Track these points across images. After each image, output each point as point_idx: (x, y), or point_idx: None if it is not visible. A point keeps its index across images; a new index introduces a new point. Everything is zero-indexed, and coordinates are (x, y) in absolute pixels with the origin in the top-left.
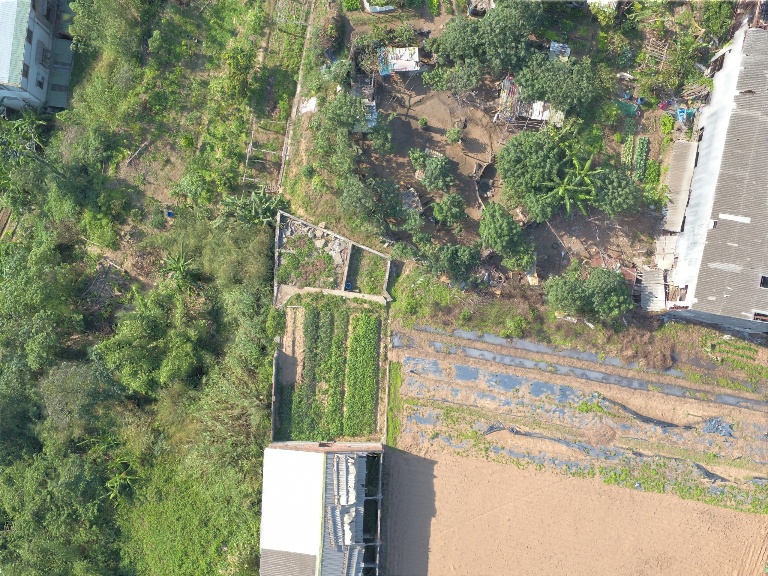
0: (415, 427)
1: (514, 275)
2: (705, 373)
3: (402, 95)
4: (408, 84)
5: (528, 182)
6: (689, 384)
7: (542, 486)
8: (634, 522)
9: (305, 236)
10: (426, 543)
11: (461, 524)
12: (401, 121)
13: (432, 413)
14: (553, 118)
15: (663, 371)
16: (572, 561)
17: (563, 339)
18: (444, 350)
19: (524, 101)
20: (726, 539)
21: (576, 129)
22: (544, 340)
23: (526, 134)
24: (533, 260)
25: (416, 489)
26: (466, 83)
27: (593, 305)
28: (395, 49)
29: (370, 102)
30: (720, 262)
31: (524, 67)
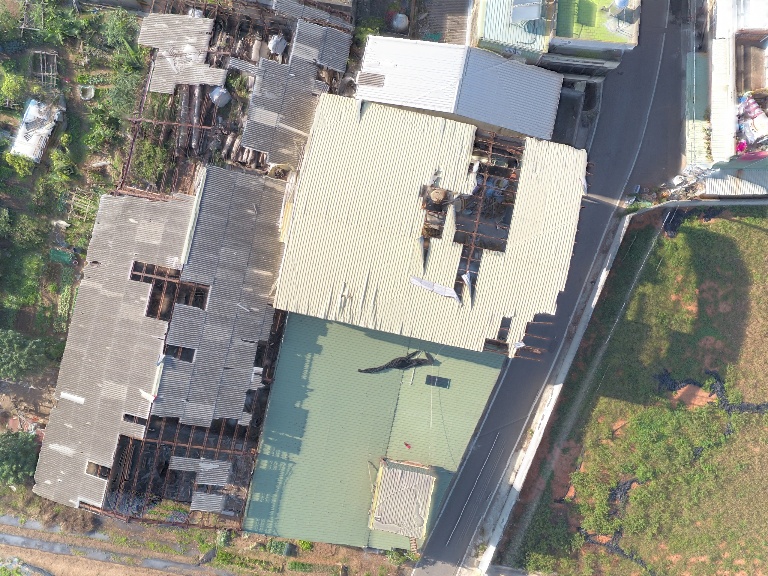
0: None
1: None
2: (131, 536)
3: None
4: None
5: None
6: (115, 548)
7: None
8: None
9: None
10: None
11: None
12: None
13: None
14: None
15: (86, 535)
16: None
17: None
18: None
19: None
20: None
21: None
22: None
23: None
24: None
25: None
26: None
27: None
28: None
29: None
30: (57, 444)
31: None
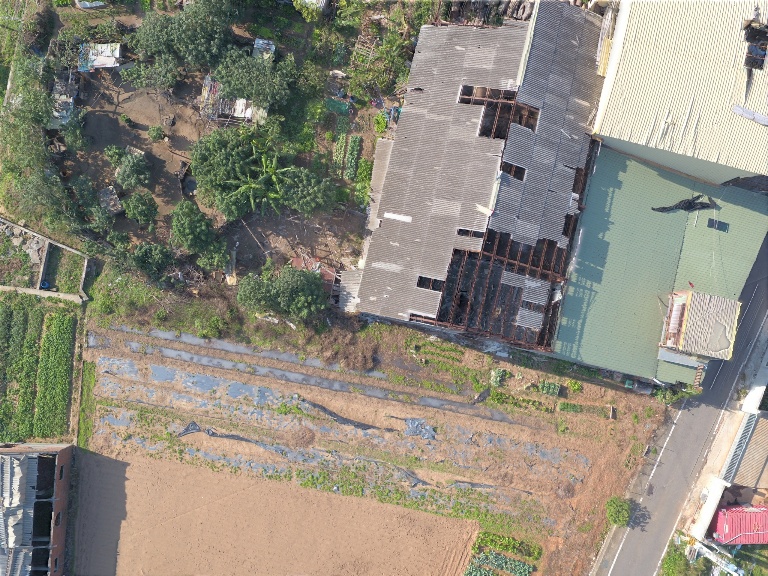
0: (108, 428)
1: (217, 274)
2: (409, 375)
3: (110, 92)
4: (117, 81)
5: (213, 180)
6: (392, 386)
7: (237, 489)
8: (331, 526)
9: (2, 234)
10: (115, 546)
11: (152, 527)
12: (109, 118)
13: (126, 414)
14: (255, 116)
15: (365, 373)
16: (266, 565)
17: (262, 340)
18: (140, 350)
19: (226, 98)
20: (426, 544)
21: (272, 127)
22: (243, 340)
23: (216, 131)
24: (227, 259)
25: (107, 491)
26: (162, 80)
27: (280, 305)
28: (97, 45)
29: (67, 98)
30: (382, 262)
31: (220, 64)
